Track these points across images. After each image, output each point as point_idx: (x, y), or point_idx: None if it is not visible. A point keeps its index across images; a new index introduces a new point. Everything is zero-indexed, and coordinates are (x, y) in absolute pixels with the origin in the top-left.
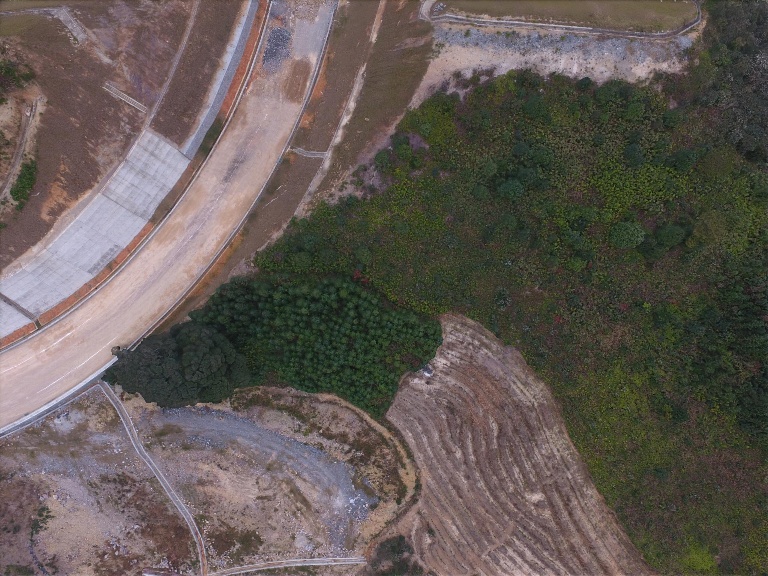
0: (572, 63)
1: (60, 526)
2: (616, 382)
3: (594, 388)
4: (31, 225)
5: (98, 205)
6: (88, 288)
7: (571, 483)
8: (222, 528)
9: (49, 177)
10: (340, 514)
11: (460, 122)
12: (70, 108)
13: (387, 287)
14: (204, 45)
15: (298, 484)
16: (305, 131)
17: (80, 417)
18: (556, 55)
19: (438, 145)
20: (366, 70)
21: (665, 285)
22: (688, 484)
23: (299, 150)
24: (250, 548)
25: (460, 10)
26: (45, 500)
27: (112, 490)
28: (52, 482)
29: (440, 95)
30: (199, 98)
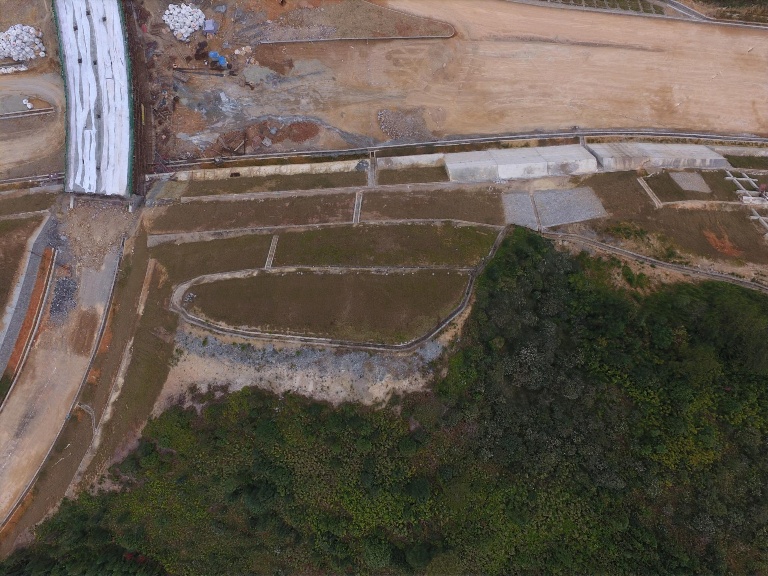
0: (307, 381)
1: None
2: None
3: None
4: None
5: None
6: None
7: None
8: None
9: None
10: None
11: None
12: None
13: (165, 562)
14: None
15: None
16: (92, 387)
17: None
18: (291, 371)
19: (182, 454)
20: (133, 345)
21: None
22: None
23: (86, 407)
24: None
25: (201, 311)
26: None
27: None
28: None
29: (171, 415)
30: None
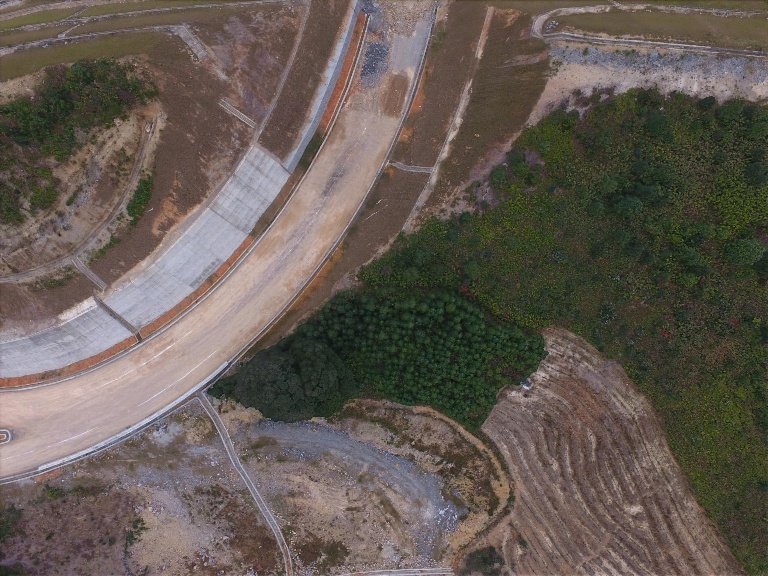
0: (692, 82)
1: (153, 538)
2: (719, 396)
3: (697, 402)
4: (142, 240)
5: (206, 220)
6: (189, 301)
7: (671, 496)
8: (308, 539)
9: (163, 193)
10: (429, 525)
11: (579, 140)
12: (187, 124)
13: (492, 301)
14: (309, 60)
15: (389, 495)
16: (404, 145)
17: (178, 430)
18: (676, 74)
19: (555, 162)
20: (472, 86)
21: None
22: None
23: (398, 164)
24: (336, 559)
25: (576, 28)
26: (140, 512)
27: (205, 502)
28: (148, 494)
29: (562, 113)
30: (302, 113)
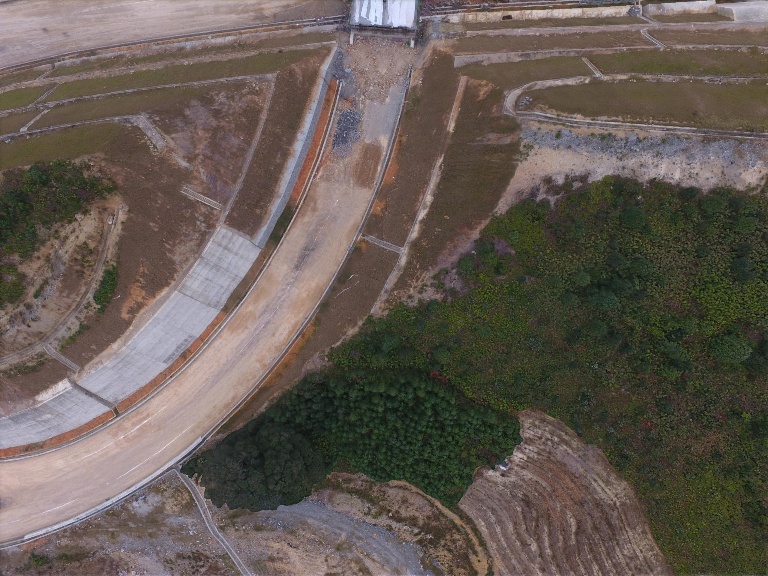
0: (674, 168)
1: None
2: (706, 487)
3: (682, 492)
4: (112, 325)
5: (175, 302)
6: (163, 377)
7: None
8: None
9: (129, 280)
10: None
11: (550, 229)
12: (150, 214)
13: (465, 385)
14: (276, 136)
15: (367, 564)
16: (377, 218)
17: (157, 500)
18: (657, 159)
19: (526, 252)
20: (444, 162)
21: (767, 396)
22: None
23: (371, 238)
24: None
25: (550, 108)
26: (124, 575)
27: (186, 565)
28: (130, 559)
29: (530, 204)
30: (271, 189)
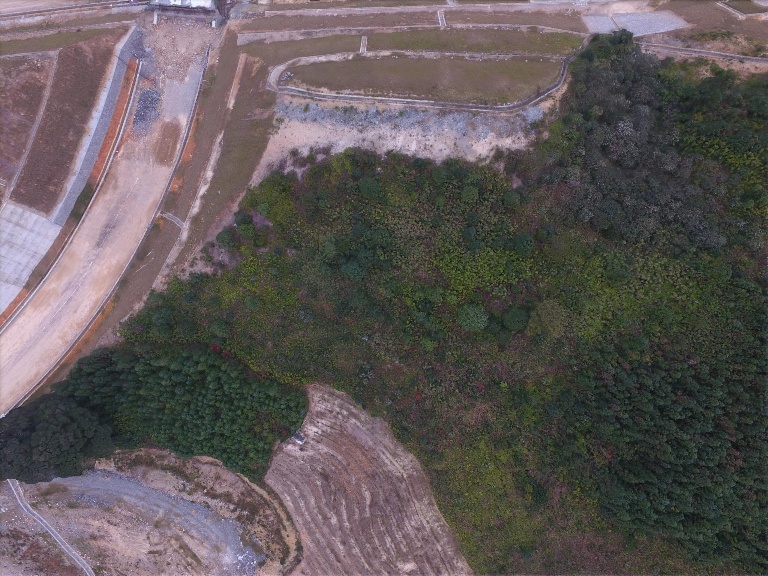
0: (411, 140)
1: None
2: (482, 457)
3: (460, 462)
4: None
5: None
6: None
7: (441, 555)
8: None
9: None
10: (229, 570)
11: (299, 201)
12: None
13: (249, 359)
14: (65, 113)
15: (186, 541)
16: (174, 196)
17: None
18: (394, 131)
19: (279, 224)
20: (223, 138)
21: (520, 365)
22: (553, 564)
23: (169, 215)
24: None
25: (302, 82)
26: None
27: (7, 544)
28: None
29: (274, 176)
30: (65, 166)
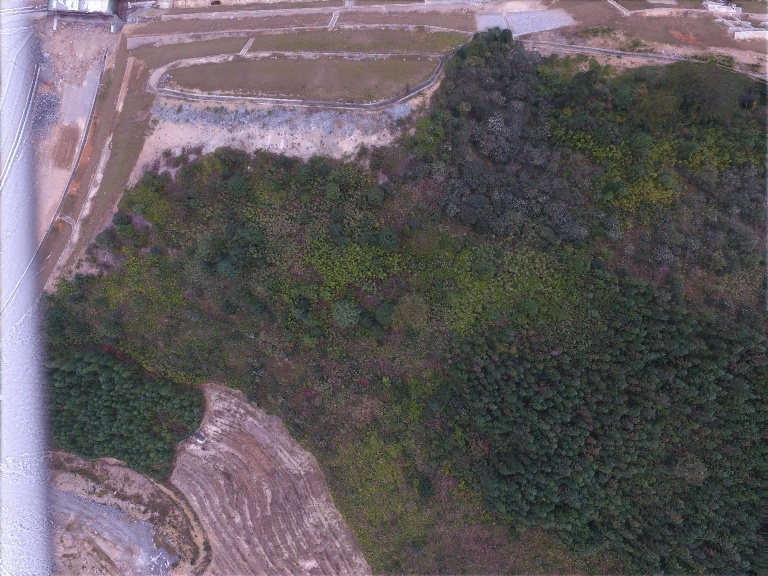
0: (279, 139)
1: None
2: (374, 453)
3: (353, 459)
4: None
5: None
6: None
7: (339, 552)
8: None
9: None
10: (143, 572)
11: None
12: None
13: (143, 359)
14: None
15: (99, 543)
16: (73, 199)
17: None
18: (263, 131)
19: (157, 224)
20: (112, 140)
21: (400, 360)
22: (444, 558)
23: (67, 218)
24: None
25: (177, 84)
26: None
27: None
28: None
29: (146, 176)
30: None
